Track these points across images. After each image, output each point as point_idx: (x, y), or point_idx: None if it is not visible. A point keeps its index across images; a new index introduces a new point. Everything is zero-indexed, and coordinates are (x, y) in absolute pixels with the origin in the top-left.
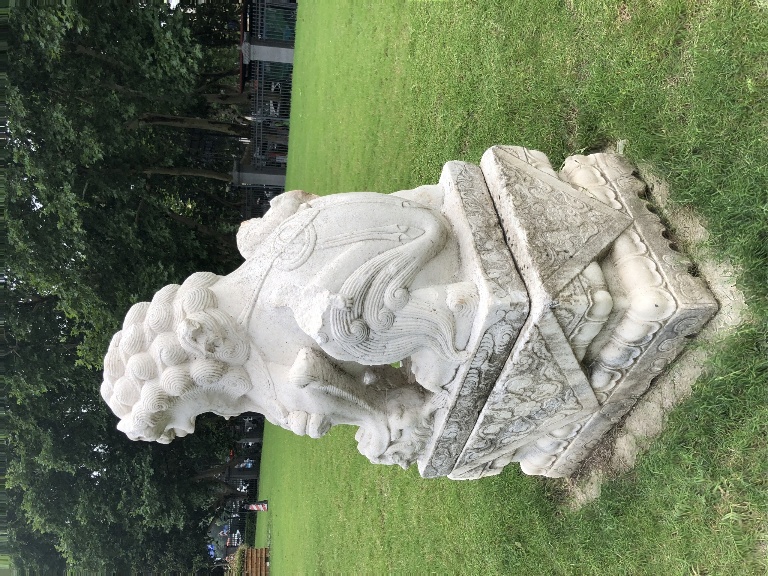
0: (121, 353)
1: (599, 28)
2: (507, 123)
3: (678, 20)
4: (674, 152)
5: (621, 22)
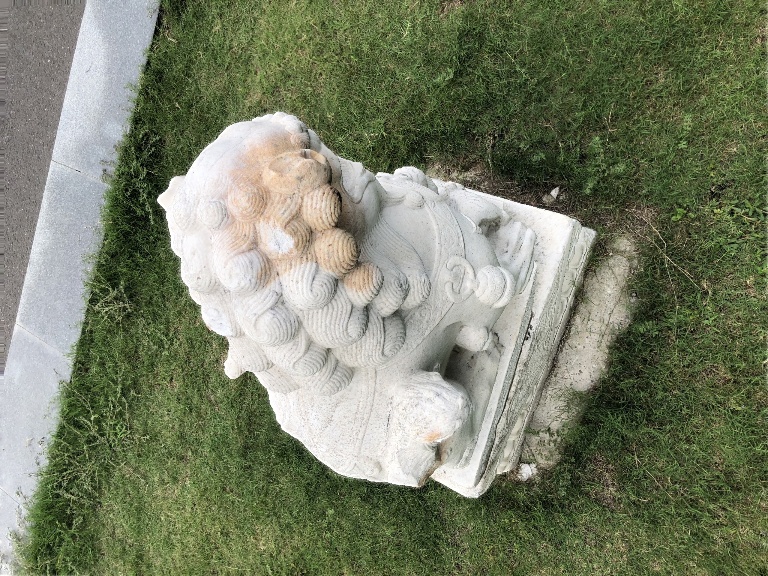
0: (200, 298)
1: (577, 574)
2: (766, 465)
3: (478, 570)
4: (438, 484)
5: (541, 575)
